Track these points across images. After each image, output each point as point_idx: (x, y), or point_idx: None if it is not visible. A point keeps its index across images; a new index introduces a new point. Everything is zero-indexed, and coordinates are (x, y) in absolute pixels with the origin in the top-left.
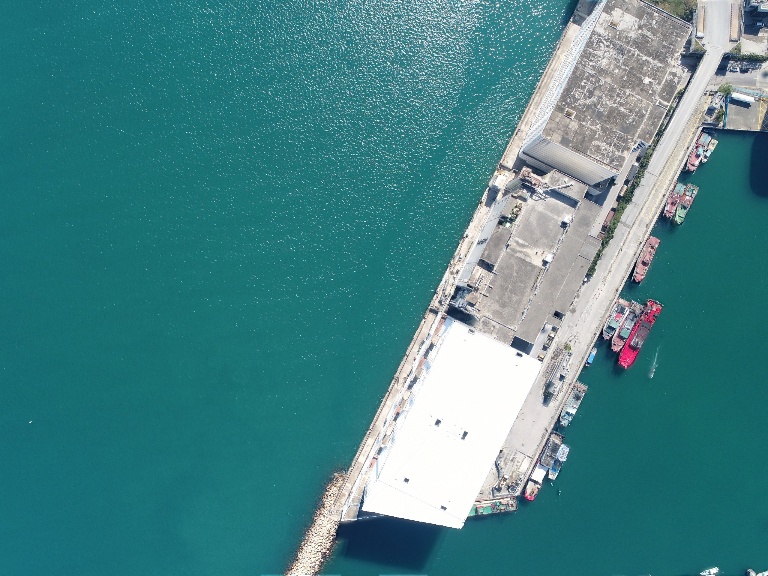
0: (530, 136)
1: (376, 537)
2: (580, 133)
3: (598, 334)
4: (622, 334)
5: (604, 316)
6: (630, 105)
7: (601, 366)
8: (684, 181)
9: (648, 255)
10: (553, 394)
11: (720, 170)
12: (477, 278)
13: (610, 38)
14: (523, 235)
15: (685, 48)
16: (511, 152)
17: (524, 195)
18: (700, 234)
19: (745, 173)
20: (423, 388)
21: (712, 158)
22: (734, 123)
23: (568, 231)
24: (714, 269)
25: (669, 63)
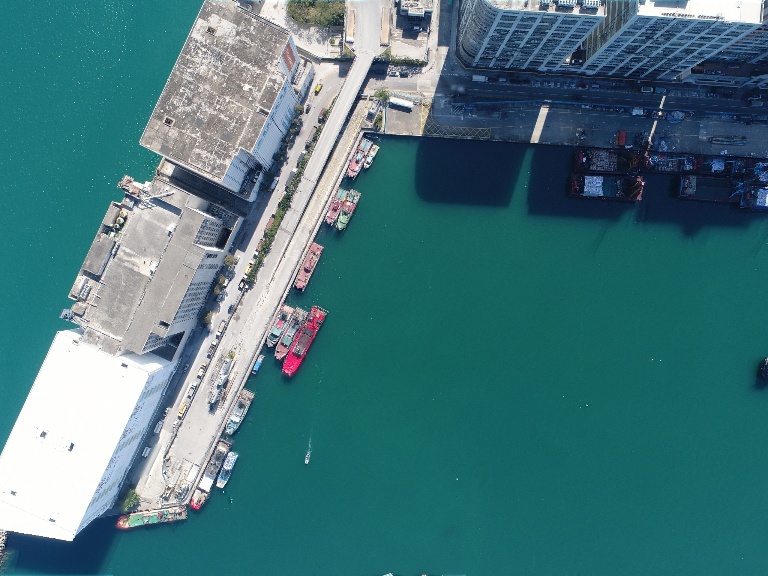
0: None
1: (44, 548)
2: (180, 141)
3: (263, 341)
4: (283, 341)
5: (268, 323)
6: (230, 112)
7: (268, 373)
8: (348, 187)
9: (308, 262)
10: (219, 402)
11: (384, 175)
12: (79, 288)
13: (208, 44)
14: (130, 244)
15: (341, 53)
16: None
17: (127, 204)
18: (366, 240)
19: (411, 178)
20: (29, 400)
21: (377, 163)
22: (396, 128)
23: (171, 240)
24: (381, 275)
25: (269, 70)
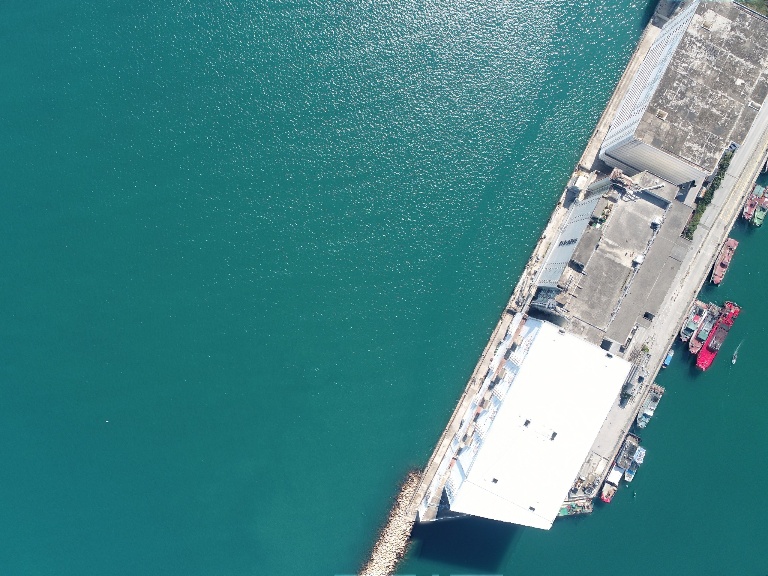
0: (613, 137)
1: (451, 538)
2: (672, 134)
3: (675, 336)
4: (700, 336)
5: (682, 318)
6: (722, 106)
7: (678, 368)
8: (762, 183)
9: (727, 257)
10: (630, 396)
11: None
12: (567, 279)
13: (703, 39)
14: (613, 236)
15: None
16: (589, 153)
17: (615, 196)
18: None
19: None
20: (512, 388)
21: None
22: None
23: (659, 232)
24: None
25: (762, 65)
